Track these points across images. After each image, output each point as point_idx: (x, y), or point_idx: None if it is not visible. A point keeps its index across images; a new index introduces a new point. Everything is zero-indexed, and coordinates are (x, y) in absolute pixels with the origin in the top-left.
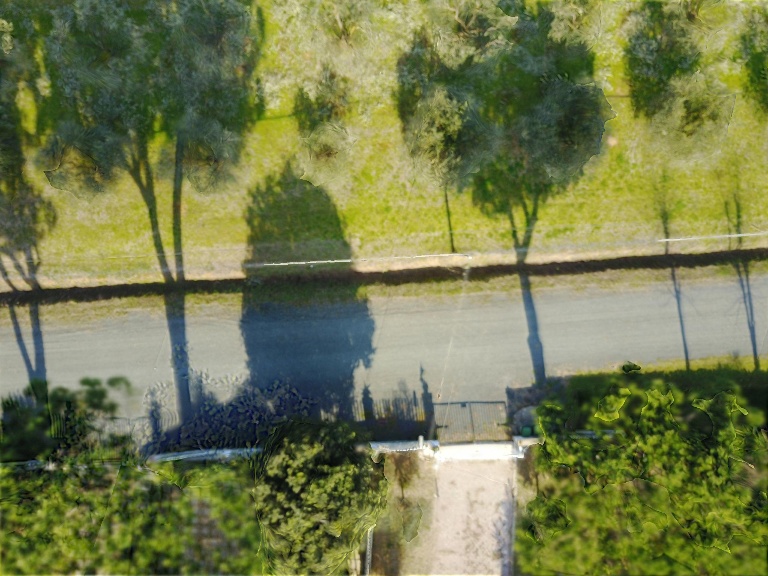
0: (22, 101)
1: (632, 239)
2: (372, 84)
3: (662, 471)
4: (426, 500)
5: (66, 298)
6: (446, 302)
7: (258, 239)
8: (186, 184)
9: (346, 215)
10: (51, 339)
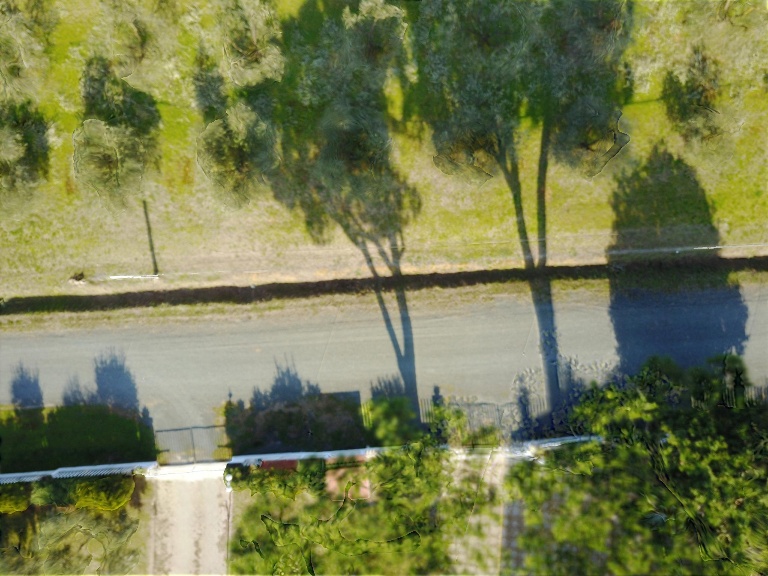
0: (389, 88)
1: None
2: (744, 66)
3: None
4: None
5: (430, 284)
6: None
7: (623, 225)
8: (551, 169)
9: (715, 200)
10: (419, 325)
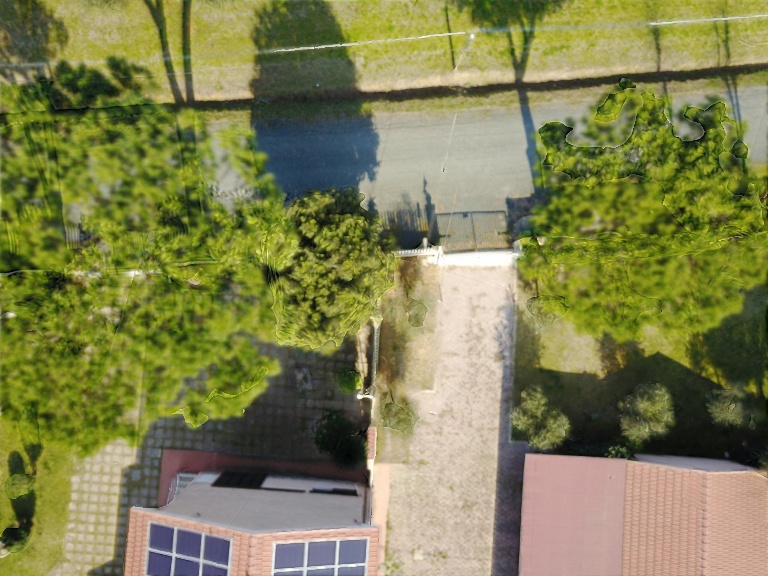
0: None
1: (626, 55)
2: None
3: (657, 162)
4: (430, 305)
5: (79, 116)
6: (448, 117)
7: (266, 59)
8: (195, 5)
9: (351, 34)
10: (65, 154)
